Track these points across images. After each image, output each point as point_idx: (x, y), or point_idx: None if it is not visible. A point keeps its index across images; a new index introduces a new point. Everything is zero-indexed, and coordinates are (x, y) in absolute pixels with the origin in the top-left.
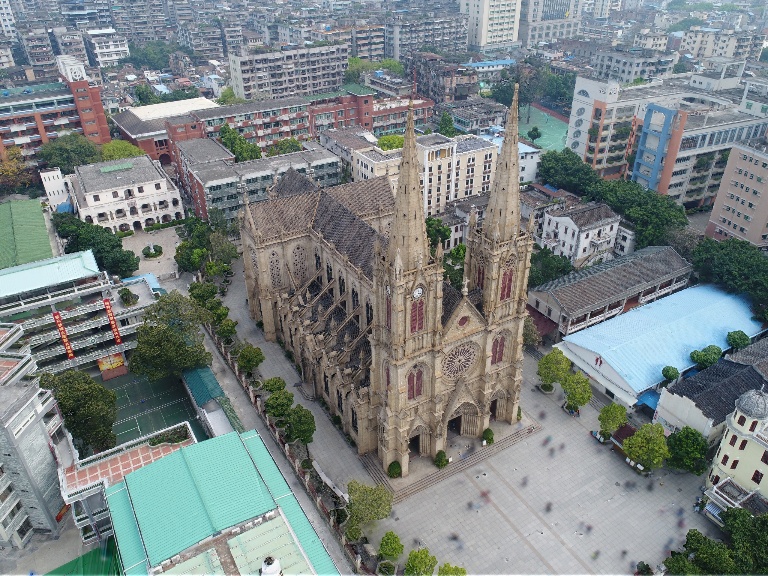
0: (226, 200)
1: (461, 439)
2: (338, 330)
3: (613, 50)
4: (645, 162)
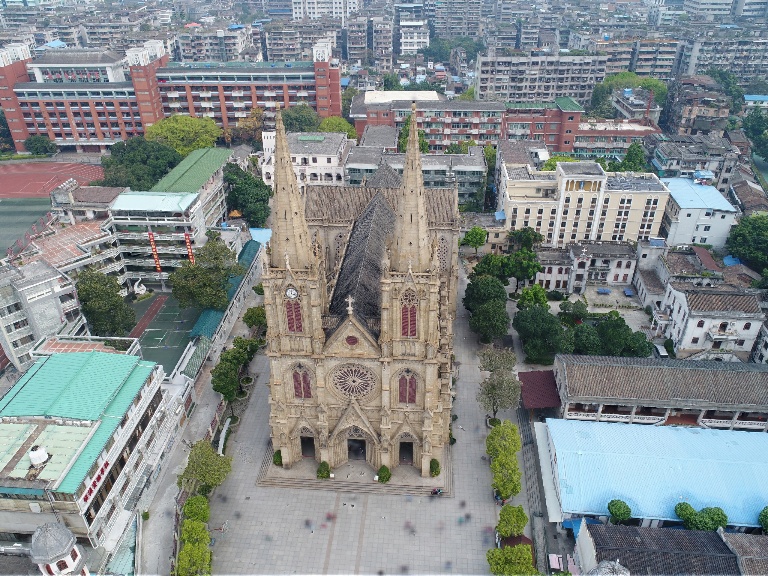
0: None
1: (363, 464)
2: None
3: None
4: None
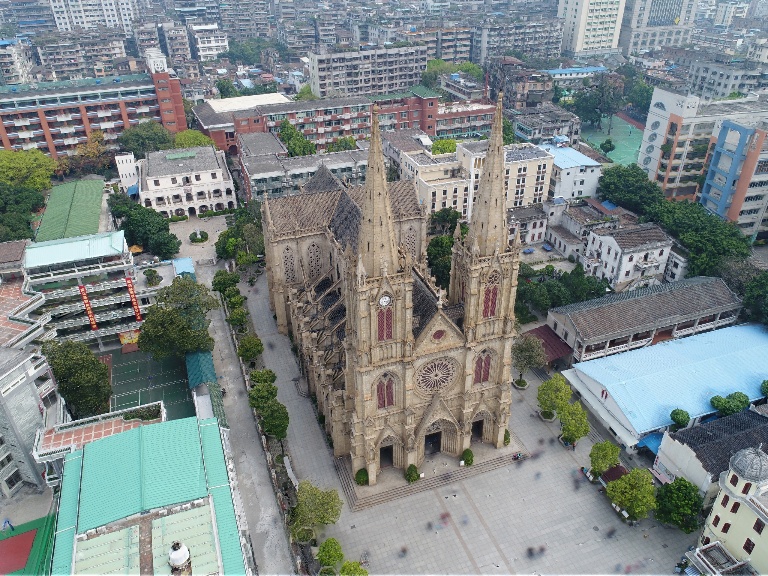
0: (271, 193)
1: (440, 456)
2: (333, 330)
3: (712, 61)
4: (715, 184)
